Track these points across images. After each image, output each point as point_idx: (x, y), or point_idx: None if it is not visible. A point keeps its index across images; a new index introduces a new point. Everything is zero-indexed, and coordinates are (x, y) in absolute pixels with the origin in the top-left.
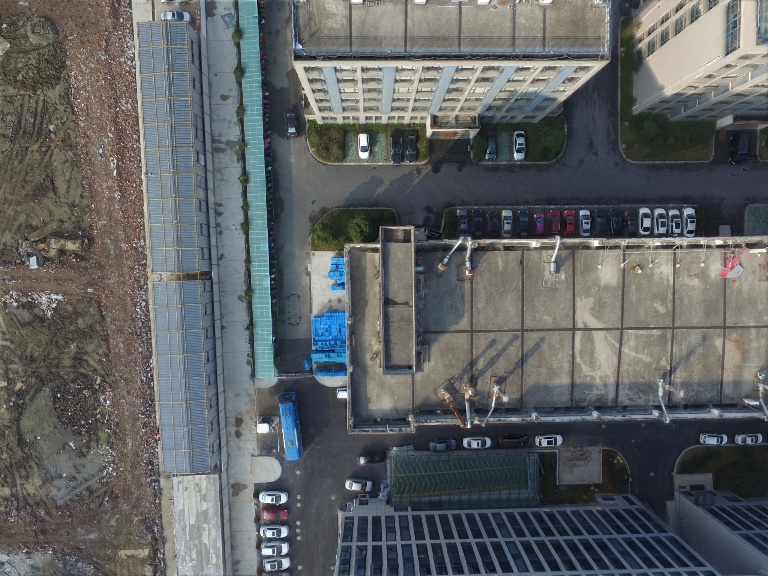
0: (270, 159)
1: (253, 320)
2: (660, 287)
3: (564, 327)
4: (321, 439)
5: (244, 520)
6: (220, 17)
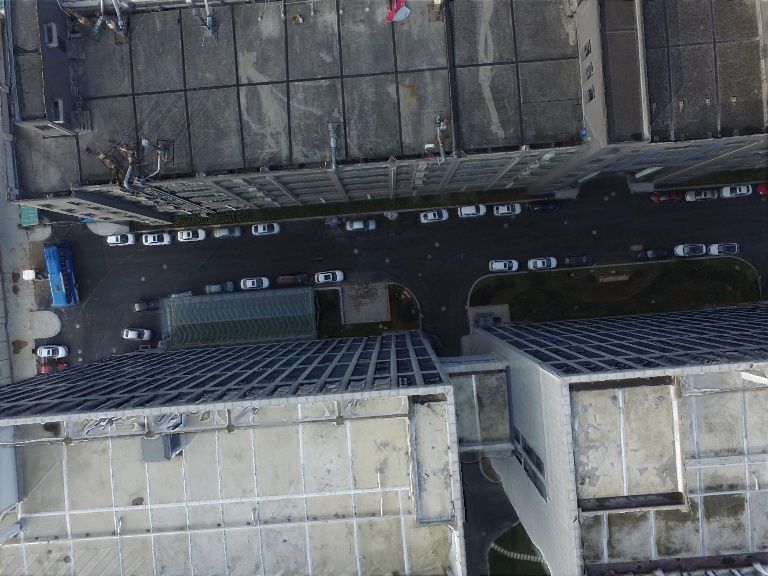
0: None
1: None
2: (325, 36)
3: (228, 84)
4: (98, 290)
5: None
6: None
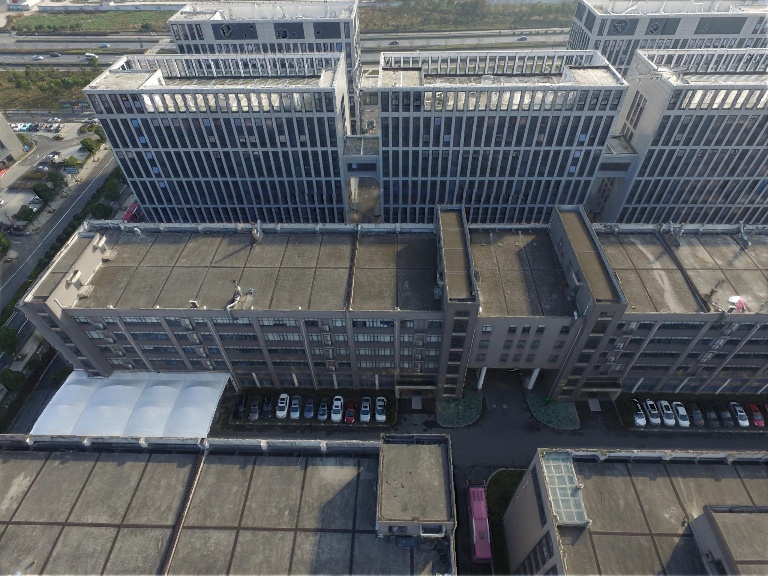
0: None
1: None
2: None
3: None
4: None
5: None
6: None
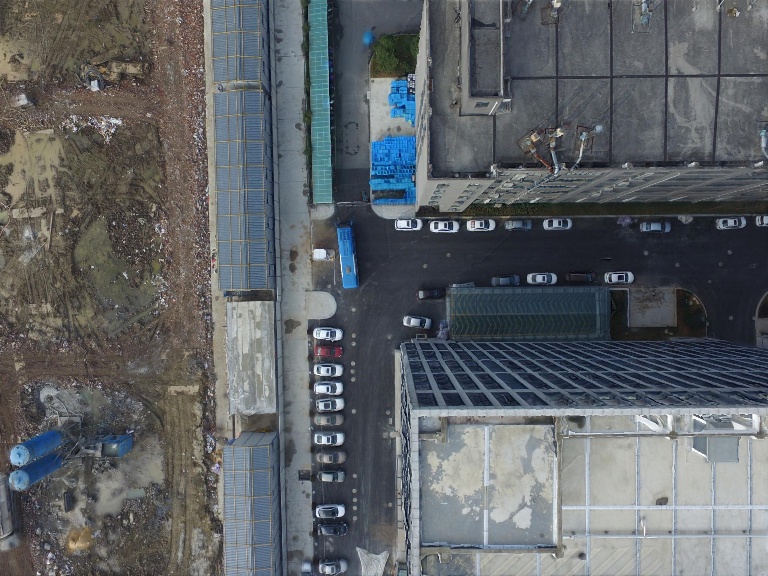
0: None
1: (311, 143)
2: (760, 31)
3: (656, 73)
4: (378, 274)
5: (297, 359)
6: None
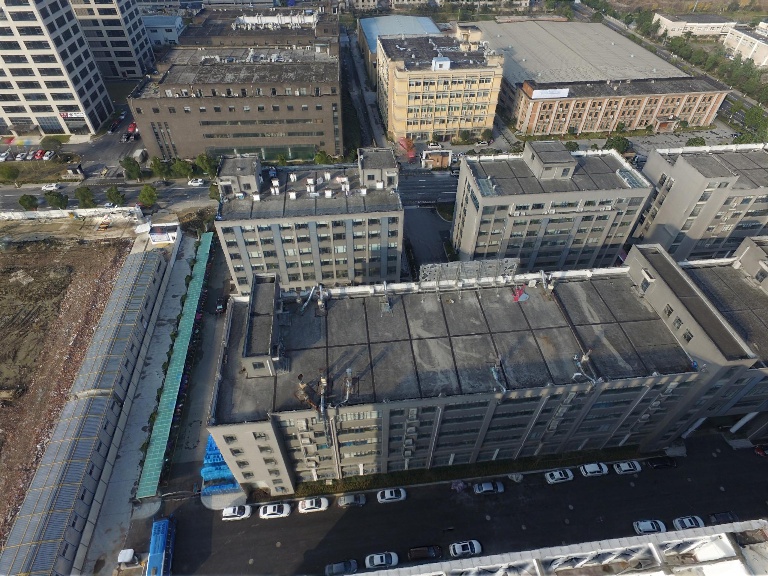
0: (199, 326)
1: (150, 440)
2: (471, 310)
3: (402, 339)
4: None
5: None
6: (185, 260)
